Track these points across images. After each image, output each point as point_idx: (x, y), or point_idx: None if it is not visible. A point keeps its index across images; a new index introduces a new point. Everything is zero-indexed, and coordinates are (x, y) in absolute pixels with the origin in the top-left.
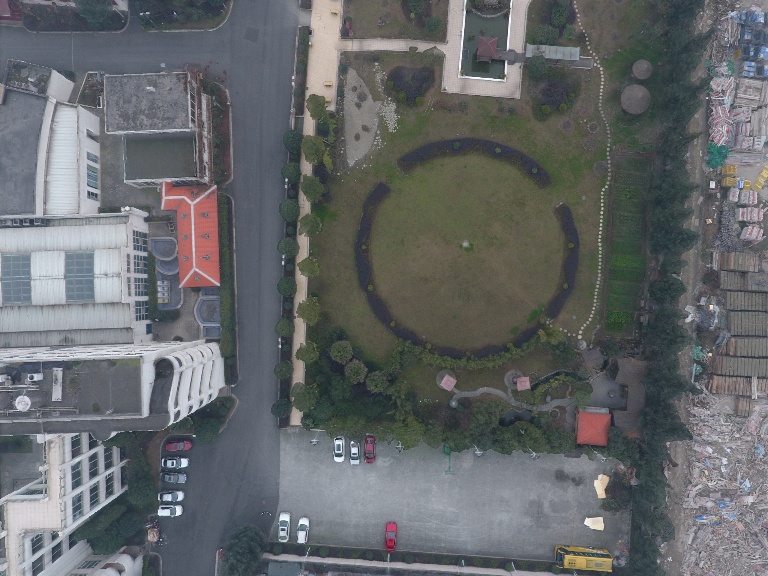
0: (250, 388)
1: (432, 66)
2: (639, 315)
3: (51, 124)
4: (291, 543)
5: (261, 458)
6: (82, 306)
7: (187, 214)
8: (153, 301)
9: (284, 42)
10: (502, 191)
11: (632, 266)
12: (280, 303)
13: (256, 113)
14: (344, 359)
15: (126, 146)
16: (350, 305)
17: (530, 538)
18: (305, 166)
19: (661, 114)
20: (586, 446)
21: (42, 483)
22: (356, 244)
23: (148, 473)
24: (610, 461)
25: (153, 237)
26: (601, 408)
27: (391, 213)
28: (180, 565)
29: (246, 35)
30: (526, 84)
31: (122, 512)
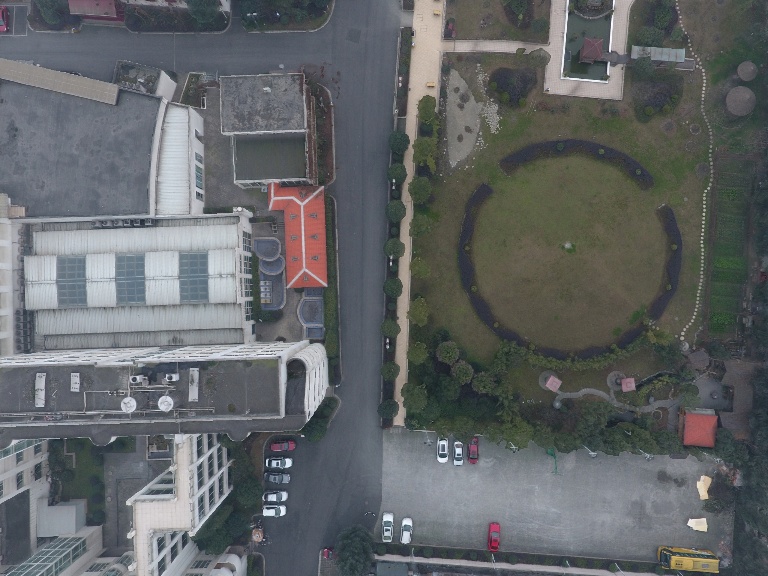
0: (353, 388)
1: (534, 67)
2: (741, 317)
3: (162, 125)
4: (394, 543)
5: (364, 458)
6: (193, 306)
7: (296, 215)
8: (257, 301)
9: (386, 43)
10: (604, 192)
11: (735, 268)
12: (383, 304)
13: (358, 114)
14: (452, 360)
15: (236, 147)
16: (452, 306)
17: (632, 539)
18: (407, 167)
19: (765, 116)
20: (693, 447)
21: (161, 483)
22: (459, 245)
23: (252, 473)
24: (712, 462)
25: (256, 238)
26: (707, 409)
27: (493, 214)
28: (283, 565)
29: (348, 36)
30: (628, 85)
31: (230, 512)
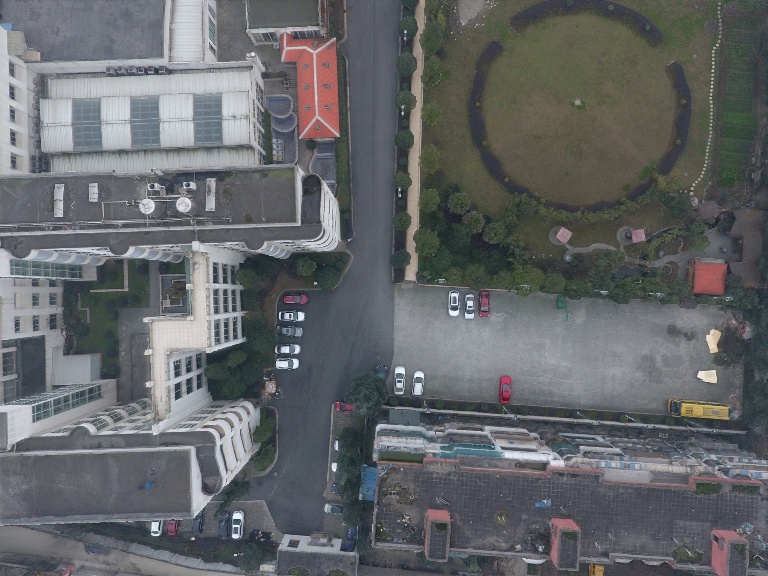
0: (365, 244)
1: None
2: (750, 172)
3: None
4: (406, 397)
5: (376, 313)
6: (207, 152)
7: (309, 64)
8: (270, 156)
9: None
10: (614, 50)
11: (743, 123)
12: (394, 160)
13: None
14: (464, 208)
15: None
16: (463, 162)
17: (643, 392)
18: (418, 25)
19: None
20: (703, 295)
21: None
22: (469, 102)
23: (265, 327)
24: (722, 316)
25: (268, 95)
26: (716, 259)
27: (503, 72)
28: (296, 419)
29: None
30: None
31: (244, 360)
